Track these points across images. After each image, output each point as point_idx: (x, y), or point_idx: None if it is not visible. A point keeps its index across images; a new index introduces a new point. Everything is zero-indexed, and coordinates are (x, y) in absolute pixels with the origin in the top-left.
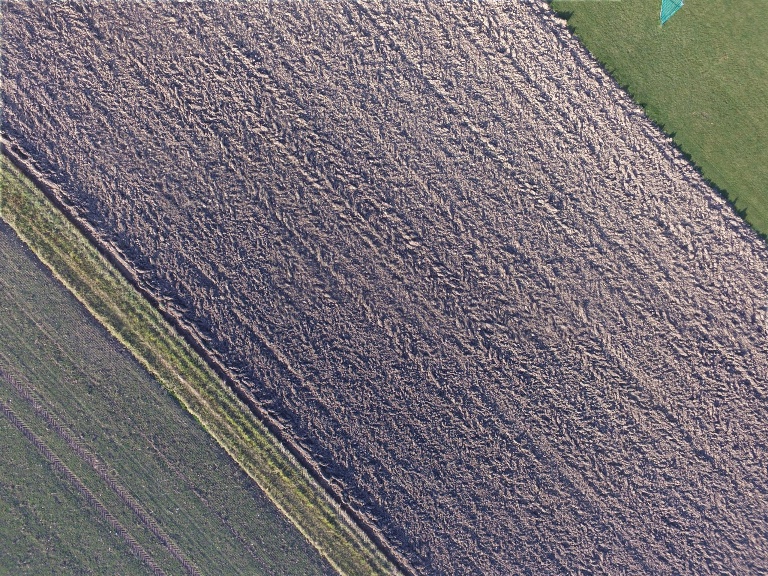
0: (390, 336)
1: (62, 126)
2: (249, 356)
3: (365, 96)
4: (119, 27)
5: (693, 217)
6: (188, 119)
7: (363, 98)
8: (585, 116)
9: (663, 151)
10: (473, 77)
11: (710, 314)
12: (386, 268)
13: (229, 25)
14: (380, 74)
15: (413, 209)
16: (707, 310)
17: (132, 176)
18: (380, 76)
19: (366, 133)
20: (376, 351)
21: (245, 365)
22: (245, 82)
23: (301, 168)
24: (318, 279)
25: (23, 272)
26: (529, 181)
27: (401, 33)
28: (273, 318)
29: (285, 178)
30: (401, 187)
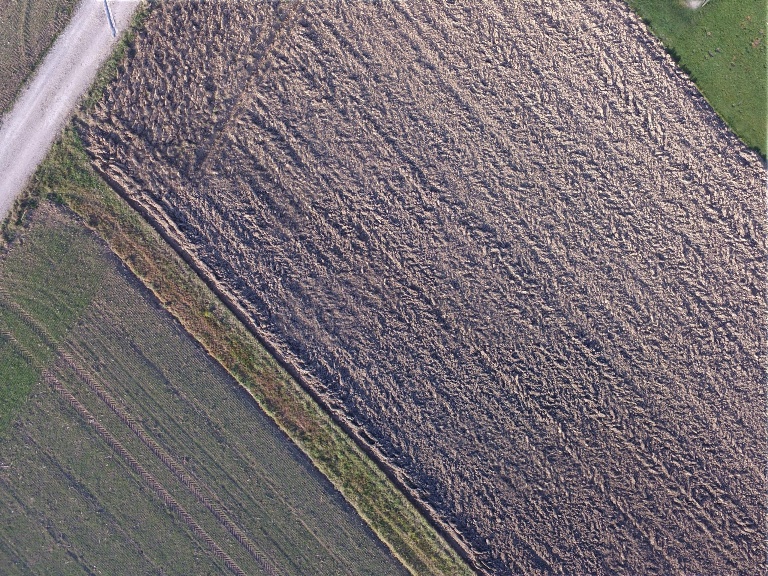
0: None
1: (406, 411)
2: None
3: (702, 385)
4: (464, 317)
5: None
6: (527, 404)
7: (701, 387)
8: None
9: None
10: None
11: None
12: (720, 553)
13: (570, 316)
14: (717, 364)
15: (747, 495)
16: None
17: (471, 459)
18: (717, 366)
19: (702, 420)
20: None
21: None
22: (584, 370)
23: (637, 454)
24: (652, 563)
25: (362, 549)
26: None
27: (739, 325)
28: None
29: (620, 462)
30: (736, 474)
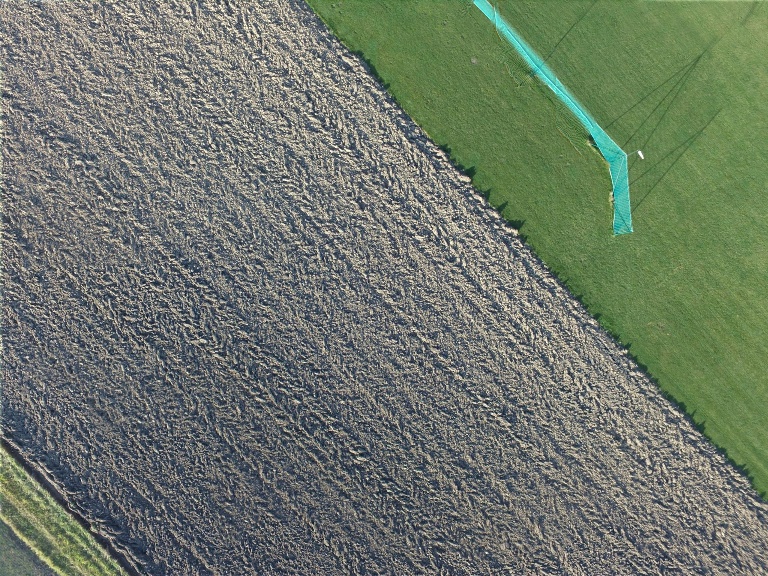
0: (337, 556)
1: None
2: None
3: (310, 306)
4: (49, 237)
5: (650, 431)
6: (122, 331)
7: (307, 309)
8: (538, 327)
9: (618, 370)
10: (422, 286)
11: (670, 531)
12: (332, 484)
13: (166, 234)
14: (325, 283)
15: (361, 422)
16: (666, 527)
17: (62, 392)
18: (325, 285)
19: (311, 344)
20: (322, 572)
21: None
22: (183, 293)
23: (242, 381)
24: (260, 497)
25: None
26: (481, 393)
27: (347, 242)
28: (213, 539)
29: (225, 391)
30: (348, 400)
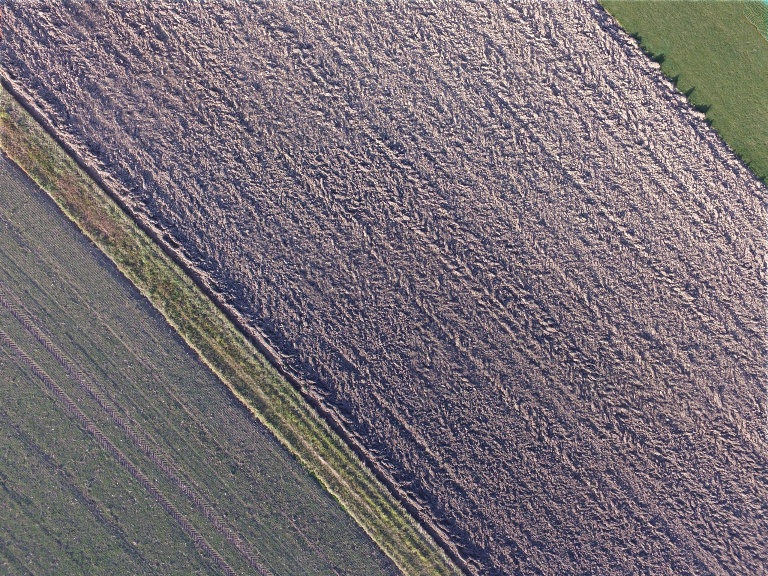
0: (527, 420)
1: (211, 216)
2: (388, 438)
3: (505, 186)
4: (268, 120)
5: None
6: (332, 208)
7: (503, 188)
8: (722, 207)
9: None
10: (611, 168)
11: None
12: (523, 353)
13: (374, 118)
14: (520, 165)
15: (550, 296)
16: None
17: (278, 263)
18: (519, 167)
19: (505, 222)
20: (513, 434)
21: (384, 447)
22: (388, 173)
23: (442, 256)
24: (457, 364)
25: (171, 355)
26: (665, 269)
27: (541, 125)
28: (412, 401)
29: (425, 265)
30: (539, 274)
